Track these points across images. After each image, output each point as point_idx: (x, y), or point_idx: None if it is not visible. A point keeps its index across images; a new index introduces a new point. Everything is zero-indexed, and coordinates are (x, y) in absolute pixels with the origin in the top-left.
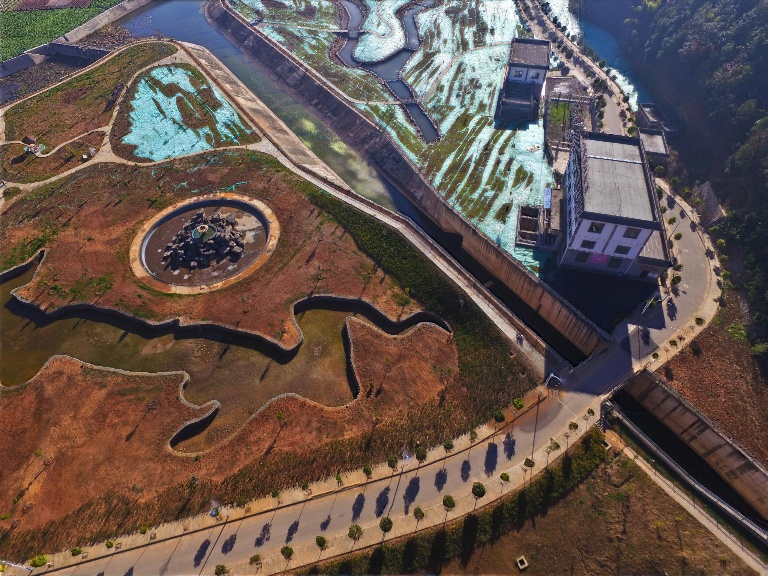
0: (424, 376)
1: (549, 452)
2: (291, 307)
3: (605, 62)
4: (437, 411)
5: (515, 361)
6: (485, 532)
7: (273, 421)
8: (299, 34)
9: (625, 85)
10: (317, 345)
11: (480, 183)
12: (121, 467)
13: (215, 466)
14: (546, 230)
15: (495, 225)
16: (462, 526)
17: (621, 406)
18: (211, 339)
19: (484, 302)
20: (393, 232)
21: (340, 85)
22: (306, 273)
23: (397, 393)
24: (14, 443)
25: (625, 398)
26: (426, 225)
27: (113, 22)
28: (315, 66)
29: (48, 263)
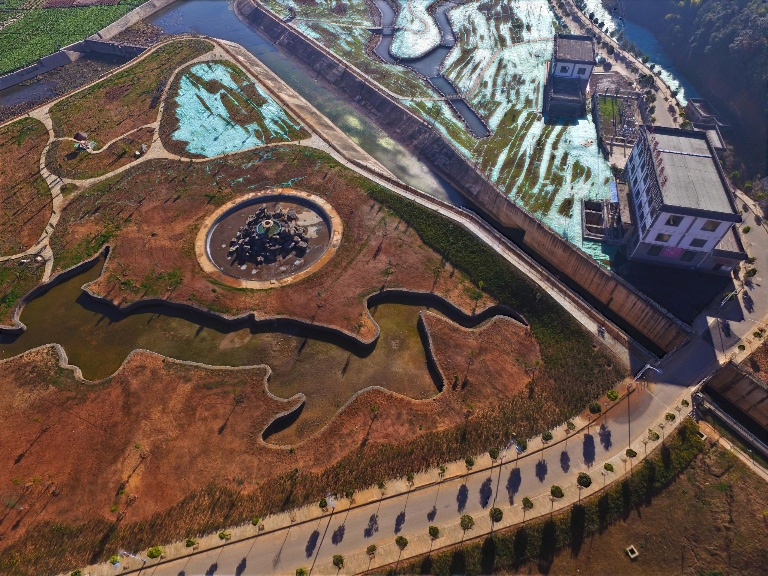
0: (508, 369)
1: (646, 443)
2: (364, 301)
3: (649, 58)
4: (528, 403)
5: (599, 353)
6: (593, 522)
7: None
8: (334, 31)
9: (670, 80)
10: (394, 339)
11: (538, 178)
12: (218, 460)
13: (312, 458)
14: (612, 224)
15: (560, 219)
16: (570, 516)
17: (712, 397)
18: (287, 333)
19: (560, 295)
20: (458, 226)
21: (382, 81)
22: (375, 267)
23: (484, 385)
24: (107, 436)
25: (710, 390)
26: None
27: (143, 19)
28: (354, 62)
29: (115, 258)
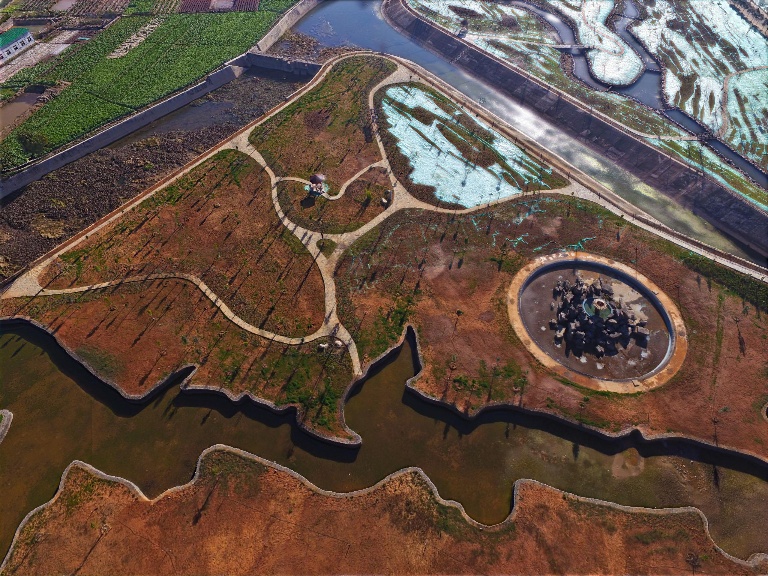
0: None
1: None
2: (764, 415)
3: None
4: None
5: None
6: None
7: None
8: (519, 49)
9: None
10: None
11: None
12: None
13: None
14: None
15: None
16: None
17: None
18: (686, 457)
19: None
20: None
21: (610, 114)
22: (751, 367)
23: None
24: None
25: None
26: None
27: (291, 28)
28: (565, 89)
29: (428, 344)
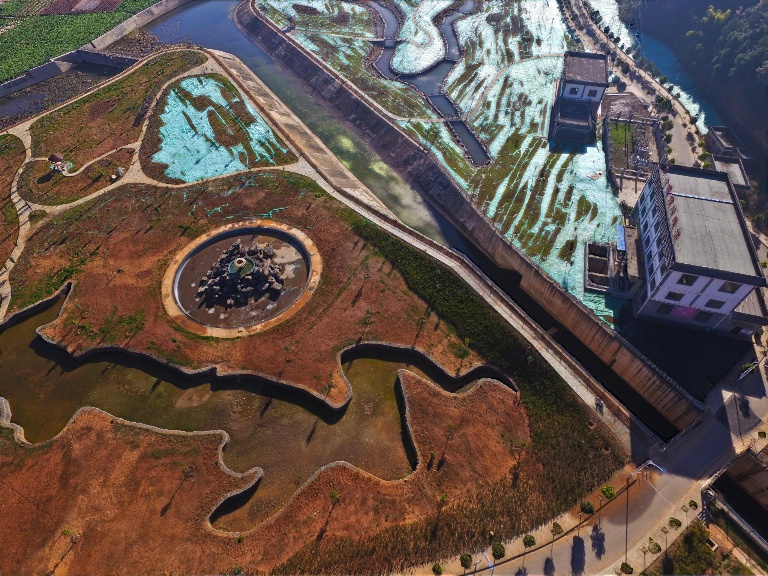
0: (492, 447)
1: (646, 552)
2: (338, 356)
3: (667, 78)
4: (511, 493)
5: (596, 433)
6: None
7: (324, 496)
8: (333, 42)
9: (690, 104)
10: (368, 402)
11: (539, 215)
12: (156, 549)
13: (261, 551)
14: (618, 273)
15: (560, 265)
16: None
17: (726, 496)
18: (251, 391)
19: (555, 358)
20: (447, 271)
21: (379, 99)
22: (353, 316)
23: (462, 467)
24: (39, 514)
25: None
26: (478, 259)
27: (141, 27)
28: (352, 78)
29: (75, 297)
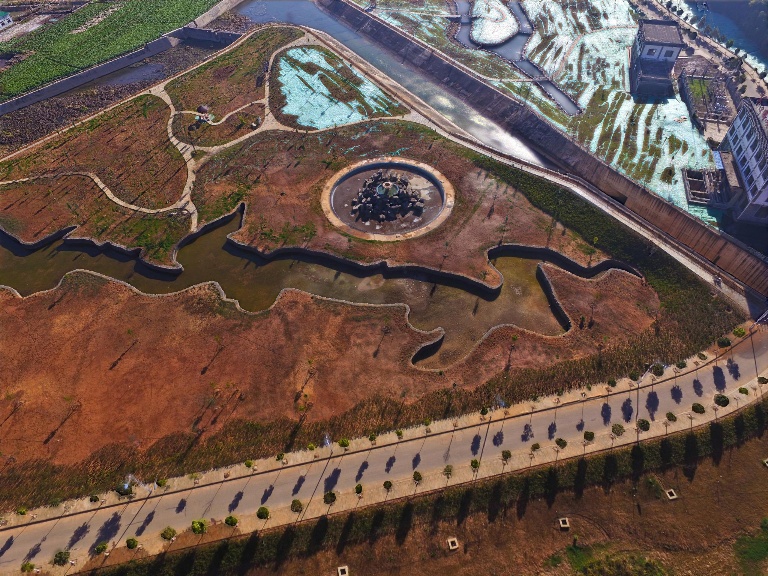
0: (631, 312)
1: None
2: (485, 253)
3: (733, 42)
4: (656, 339)
5: (718, 300)
6: (730, 437)
7: None
8: (414, 19)
9: (755, 63)
10: (516, 286)
11: (636, 150)
12: (378, 377)
13: (461, 379)
14: (715, 190)
15: (663, 186)
16: (709, 431)
17: None
18: (417, 279)
19: (673, 250)
20: (566, 191)
21: (469, 64)
22: (491, 225)
23: (610, 325)
24: (276, 356)
25: None
26: None
27: (231, 10)
28: (439, 47)
29: (252, 213)
